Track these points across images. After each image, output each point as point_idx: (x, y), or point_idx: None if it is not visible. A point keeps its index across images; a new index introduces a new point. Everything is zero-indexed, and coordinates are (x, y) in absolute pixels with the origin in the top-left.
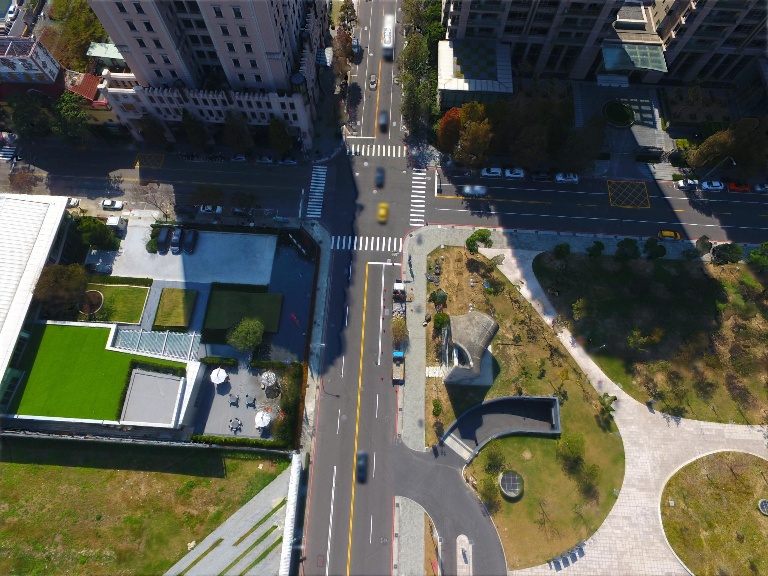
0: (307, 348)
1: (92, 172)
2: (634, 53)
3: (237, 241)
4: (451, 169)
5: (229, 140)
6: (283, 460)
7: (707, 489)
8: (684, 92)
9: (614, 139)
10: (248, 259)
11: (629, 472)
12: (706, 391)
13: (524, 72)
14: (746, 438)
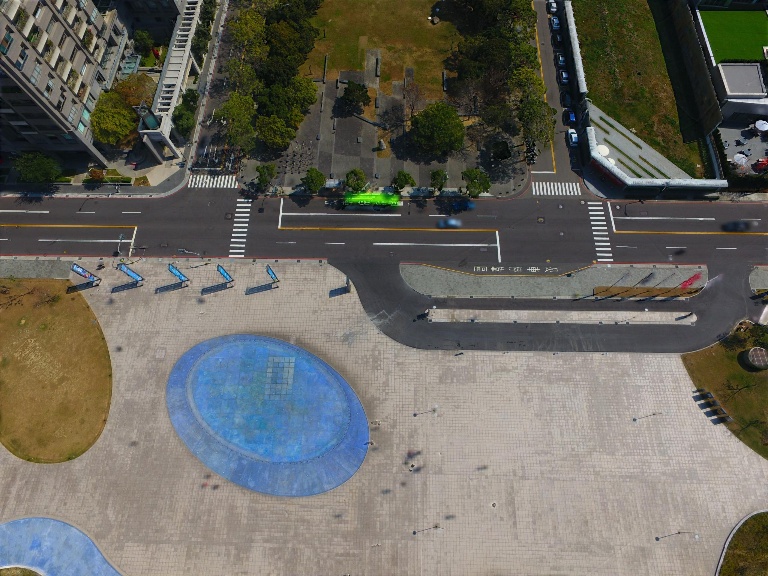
0: None
1: None
2: None
3: None
4: None
5: None
6: None
7: None
8: None
9: None
10: None
11: None
12: None
13: None
14: None
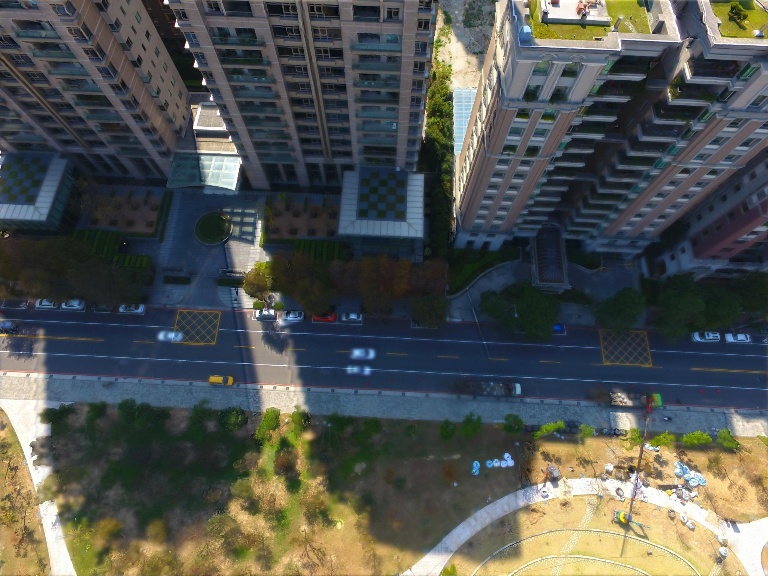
0: None
1: None
2: (207, 166)
3: None
4: (7, 299)
5: None
6: None
7: None
8: (295, 200)
9: (202, 259)
10: None
11: None
12: None
13: (124, 178)
14: None
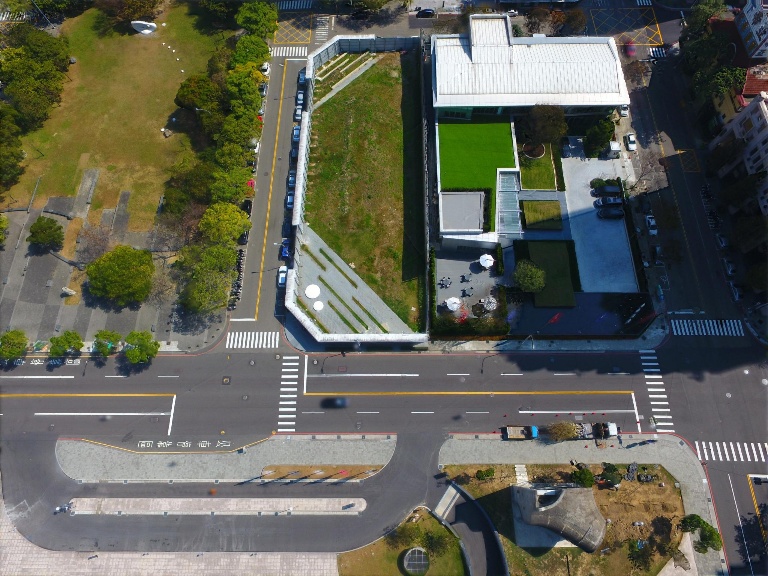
0: (525, 337)
1: (660, 118)
2: None
3: (623, 255)
4: None
5: (743, 224)
6: (420, 327)
7: None
8: None
9: None
10: (606, 268)
11: None
12: None
13: None
14: None
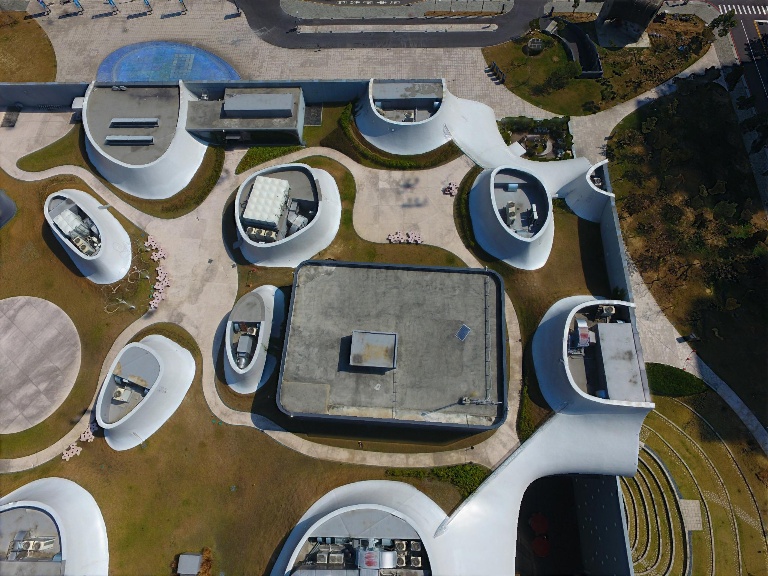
0: None
1: None
2: None
3: None
4: None
5: None
6: None
7: None
8: None
9: None
10: None
11: None
12: (634, 178)
13: None
14: None
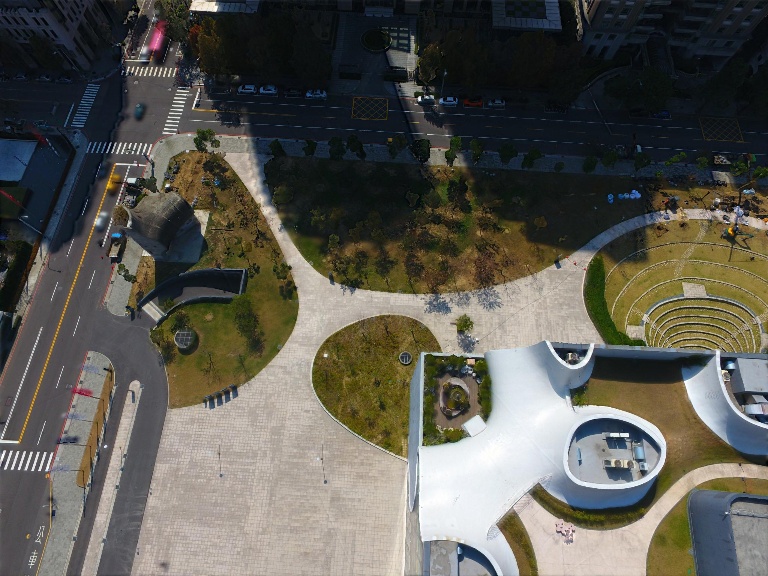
0: (41, 232)
1: None
2: None
3: (2, 145)
4: (213, 87)
5: None
6: None
7: (360, 344)
8: None
9: (368, 62)
10: (7, 160)
11: (296, 331)
12: (385, 267)
13: None
14: (408, 304)
